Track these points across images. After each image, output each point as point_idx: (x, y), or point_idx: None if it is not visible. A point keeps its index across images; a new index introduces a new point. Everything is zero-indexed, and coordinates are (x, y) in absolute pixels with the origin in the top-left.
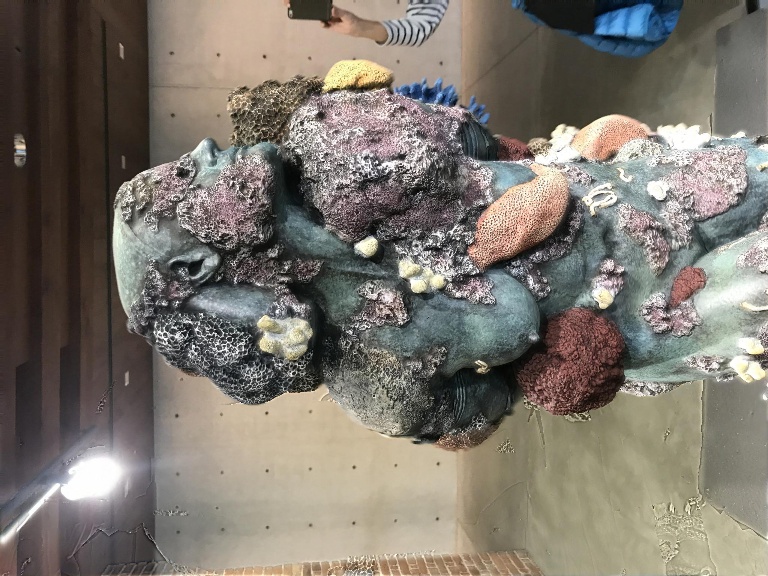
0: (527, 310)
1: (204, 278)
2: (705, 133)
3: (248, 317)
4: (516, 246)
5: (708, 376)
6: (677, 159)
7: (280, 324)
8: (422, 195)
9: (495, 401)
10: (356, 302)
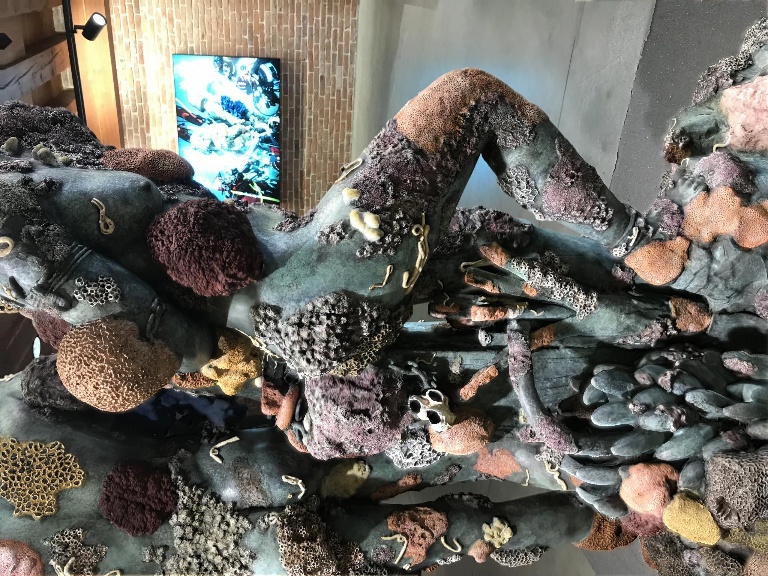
0: (142, 176)
1: None
2: None
3: None
4: (139, 162)
5: (350, 255)
6: None
7: None
8: (60, 127)
9: (134, 287)
10: None
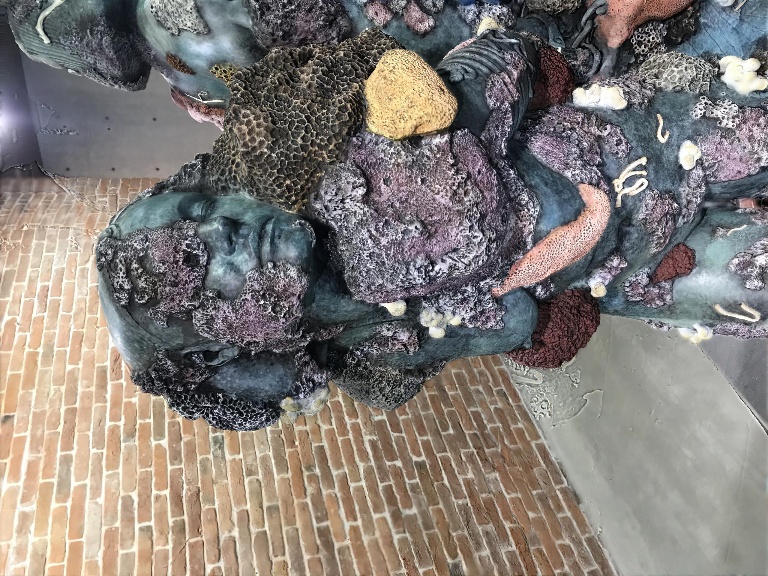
0: (529, 327)
1: (221, 363)
2: (764, 80)
3: (269, 396)
4: None
5: None
6: (723, 116)
7: (303, 404)
8: None
9: None
10: (369, 334)
